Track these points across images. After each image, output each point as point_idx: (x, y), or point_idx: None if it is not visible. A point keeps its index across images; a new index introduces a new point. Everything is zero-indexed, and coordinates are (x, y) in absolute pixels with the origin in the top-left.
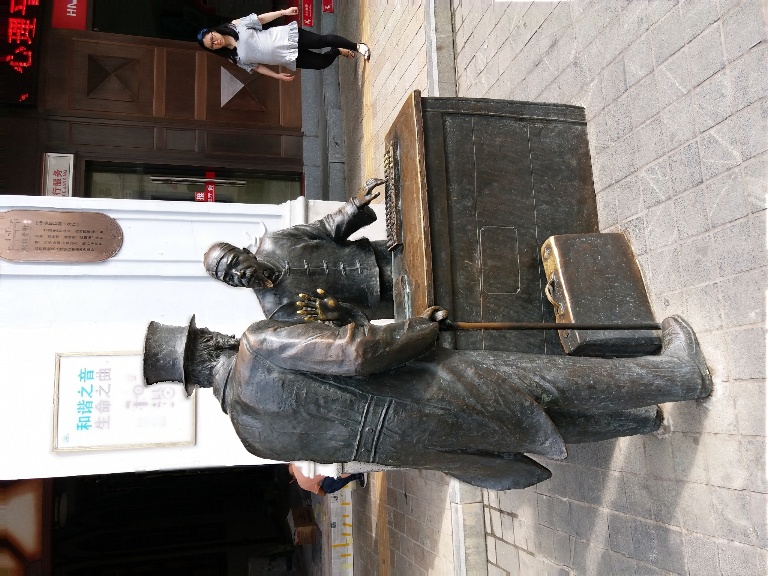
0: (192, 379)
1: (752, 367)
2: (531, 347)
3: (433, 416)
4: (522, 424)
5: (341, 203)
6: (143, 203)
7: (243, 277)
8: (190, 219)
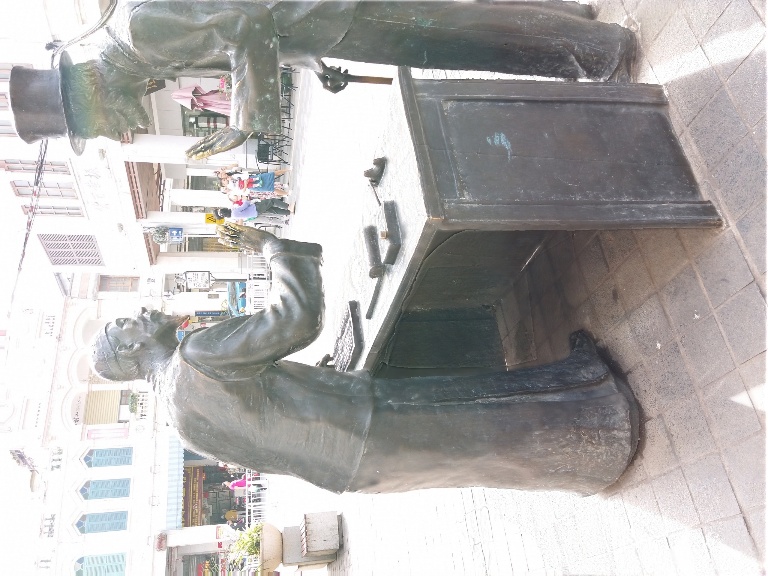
0: None
1: None
2: None
3: None
4: None
5: None
6: None
7: None
8: None
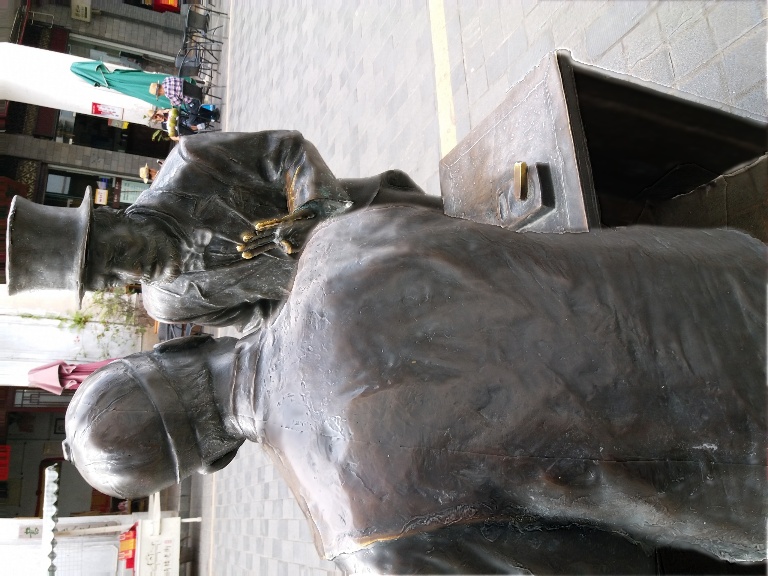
0: None
1: None
2: None
3: None
4: None
5: None
6: None
7: None
8: None
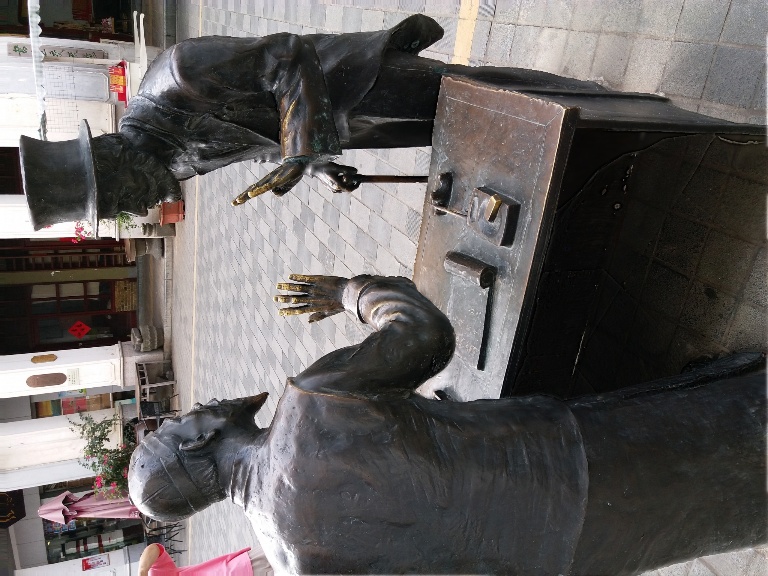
0: None
1: None
2: None
3: None
4: None
5: None
6: None
7: None
8: None
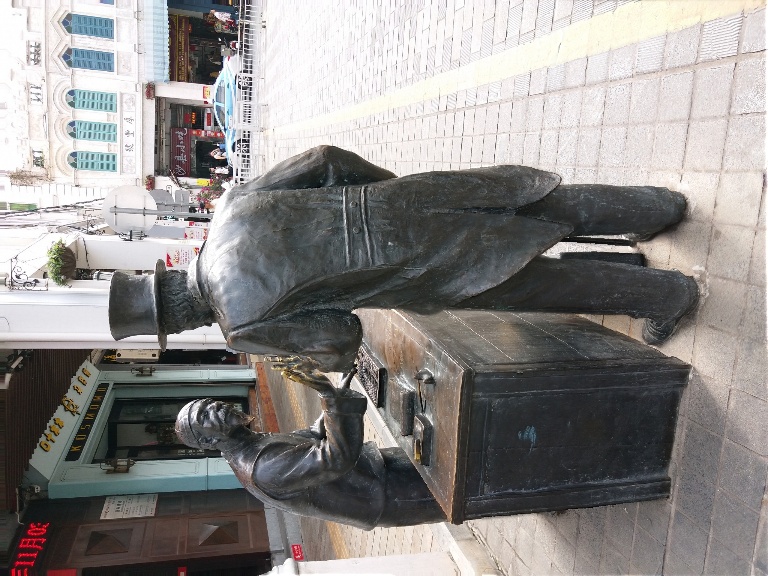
0: (162, 294)
1: (678, 143)
2: (540, 338)
3: (412, 182)
4: (502, 176)
5: (337, 562)
6: None
7: (219, 409)
8: None
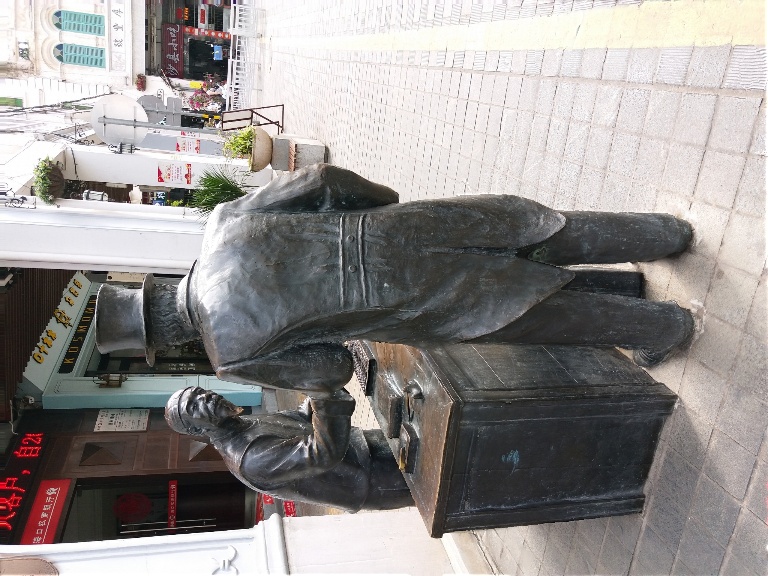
0: (151, 314)
1: (691, 168)
2: (531, 352)
3: (412, 214)
4: (506, 210)
5: (320, 519)
6: (90, 544)
7: (209, 400)
8: (145, 553)
